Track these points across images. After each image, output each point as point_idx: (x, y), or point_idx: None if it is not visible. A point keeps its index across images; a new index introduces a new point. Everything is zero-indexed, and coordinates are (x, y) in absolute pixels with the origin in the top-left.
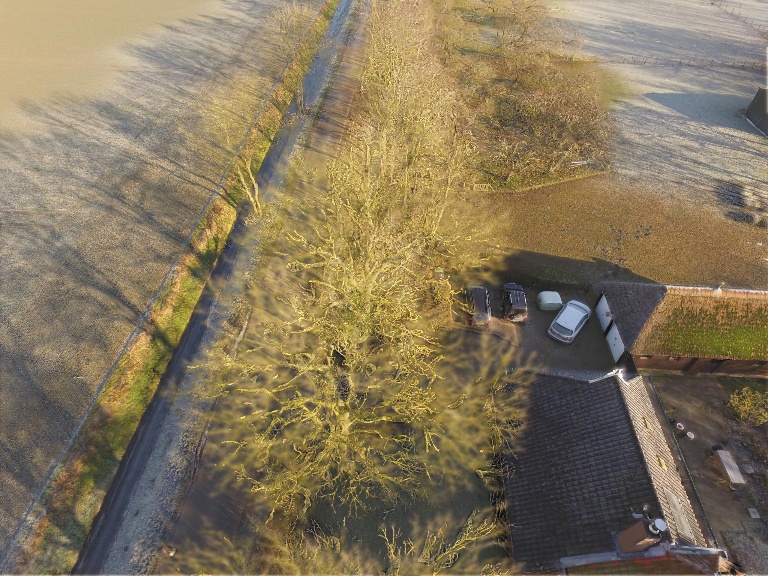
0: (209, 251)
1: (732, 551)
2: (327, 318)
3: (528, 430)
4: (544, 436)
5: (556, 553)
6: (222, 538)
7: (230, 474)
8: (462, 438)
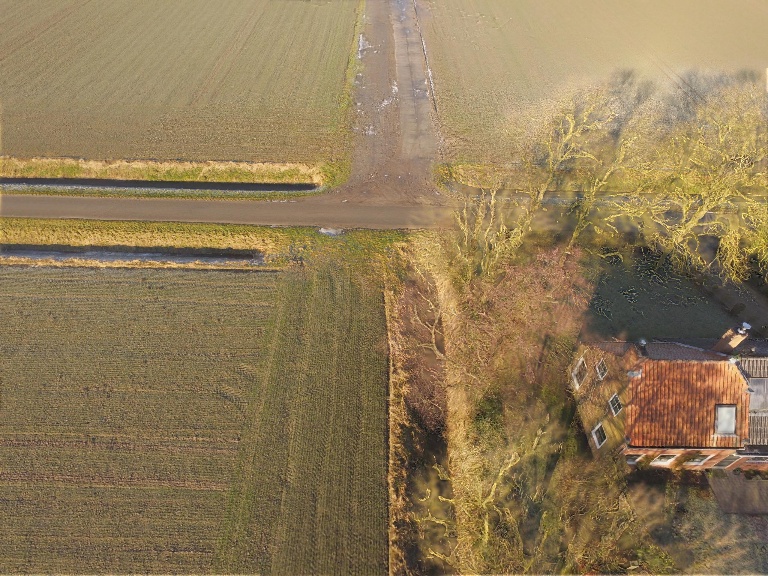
0: (764, 188)
1: (761, 516)
2: (762, 206)
3: (765, 342)
4: (767, 344)
5: (681, 342)
6: (591, 226)
7: (622, 223)
8: (725, 330)
